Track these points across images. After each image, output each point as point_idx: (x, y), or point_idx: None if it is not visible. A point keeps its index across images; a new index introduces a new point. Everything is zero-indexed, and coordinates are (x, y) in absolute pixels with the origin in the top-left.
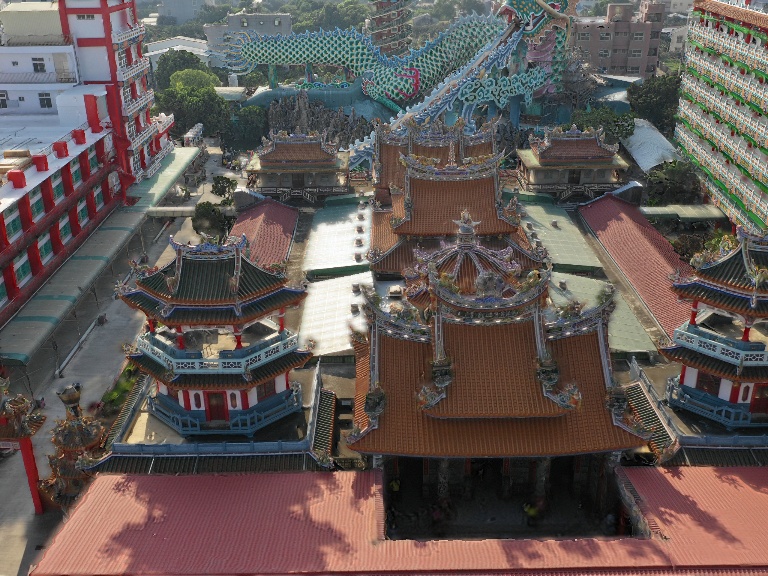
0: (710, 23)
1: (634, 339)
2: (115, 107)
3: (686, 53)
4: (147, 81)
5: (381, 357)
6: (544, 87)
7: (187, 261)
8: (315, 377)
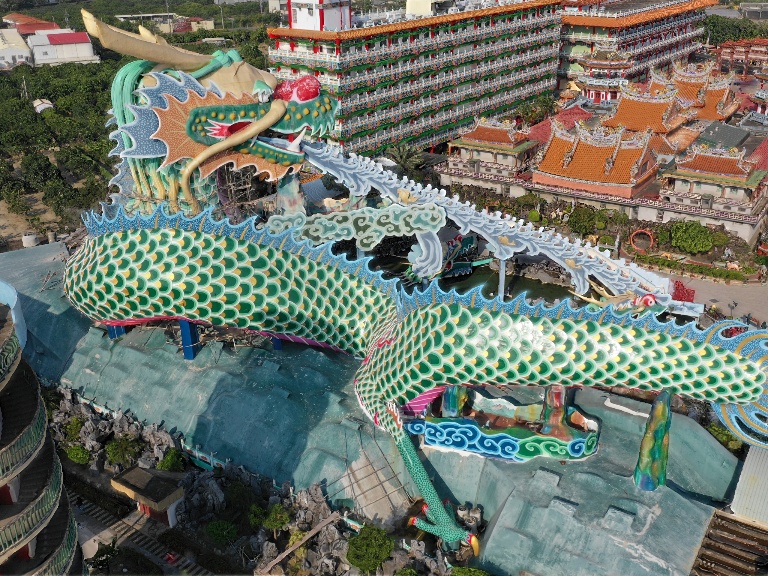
0: None
1: None
2: None
3: None
4: None
5: None
6: None
7: None
8: None
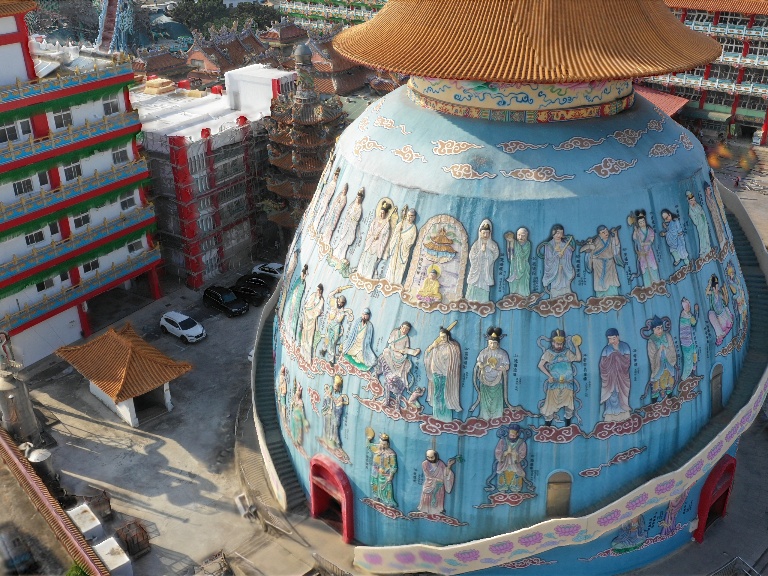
0: None
1: None
2: None
3: None
4: None
5: None
6: None
7: None
8: None
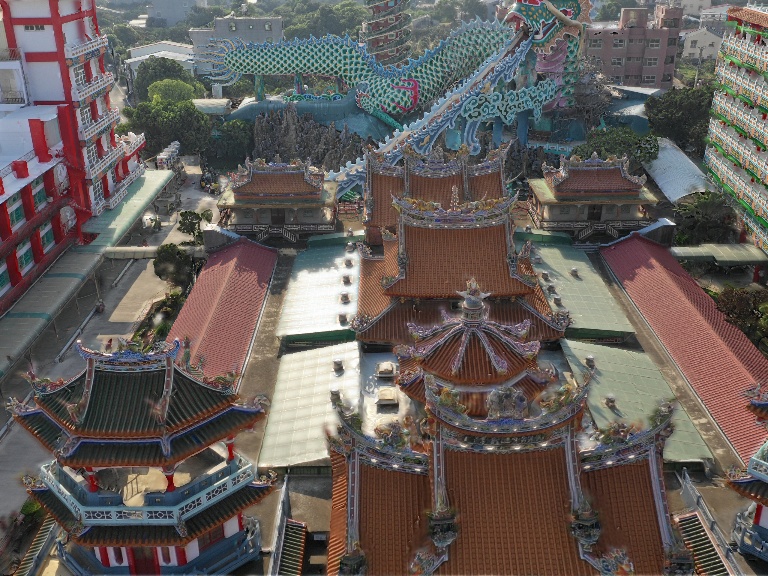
0: (748, 35)
1: (683, 441)
2: (69, 131)
3: (719, 68)
4: (128, 89)
5: (362, 497)
6: (554, 101)
7: (101, 374)
8: (280, 504)
